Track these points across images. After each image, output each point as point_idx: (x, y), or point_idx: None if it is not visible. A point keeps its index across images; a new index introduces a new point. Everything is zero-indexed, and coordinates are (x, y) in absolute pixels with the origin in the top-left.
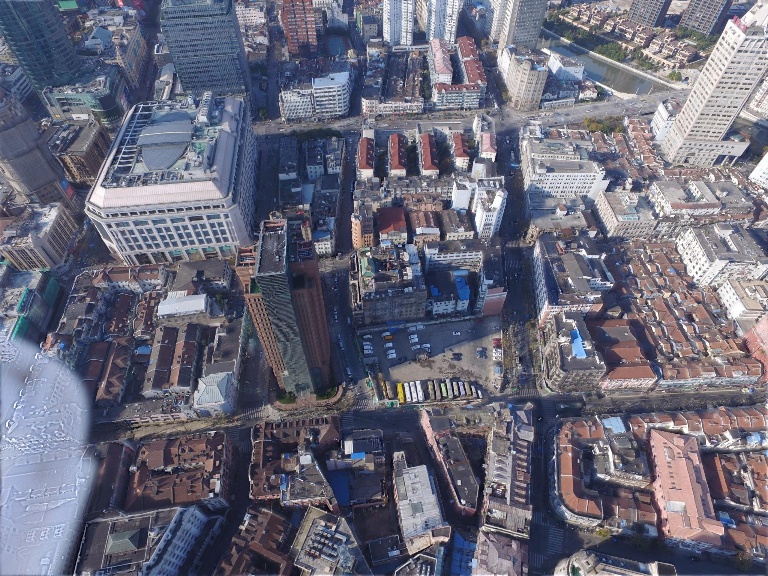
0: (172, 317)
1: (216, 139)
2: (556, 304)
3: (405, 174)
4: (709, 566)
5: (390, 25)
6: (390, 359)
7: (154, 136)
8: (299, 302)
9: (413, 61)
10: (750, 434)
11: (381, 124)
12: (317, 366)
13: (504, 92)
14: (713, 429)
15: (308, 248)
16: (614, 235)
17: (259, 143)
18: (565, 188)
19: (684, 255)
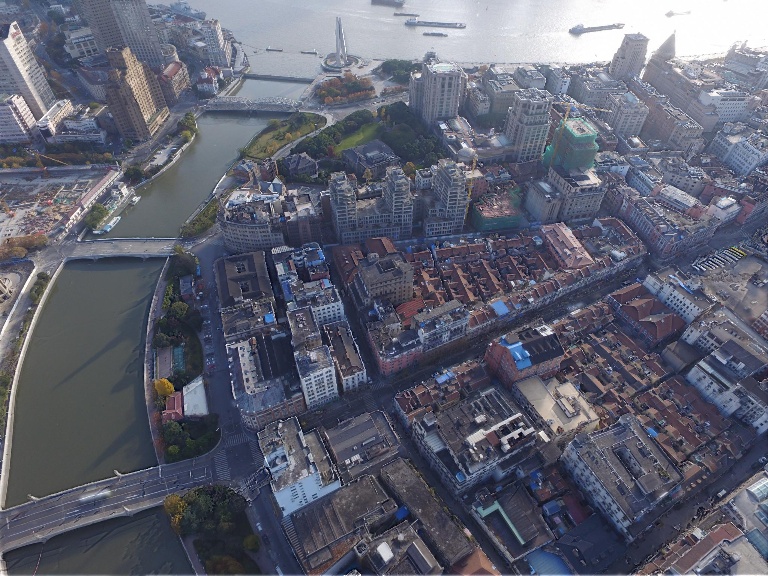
0: None
1: None
2: (723, 309)
3: None
4: None
5: None
6: None
7: None
8: None
9: None
10: None
11: None
12: None
13: None
14: None
15: None
16: None
17: None
18: None
19: None
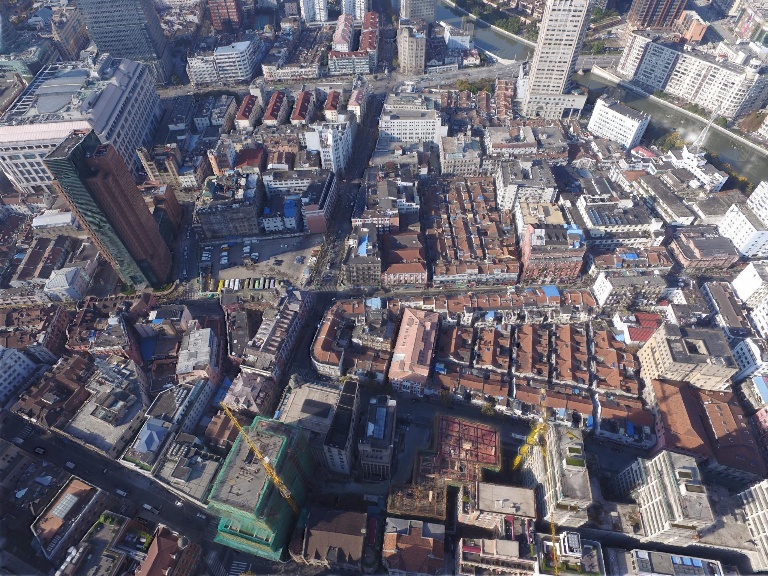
0: (45, 228)
1: (102, 90)
2: (358, 218)
3: (277, 124)
4: (426, 406)
5: (303, 2)
6: (222, 264)
7: (50, 88)
8: (97, 191)
9: (322, 34)
10: (487, 312)
11: (279, 88)
12: (142, 258)
13: (394, 59)
14: (456, 308)
15: (105, 149)
16: (445, 172)
17: (166, 103)
18: (412, 134)
19: (497, 186)
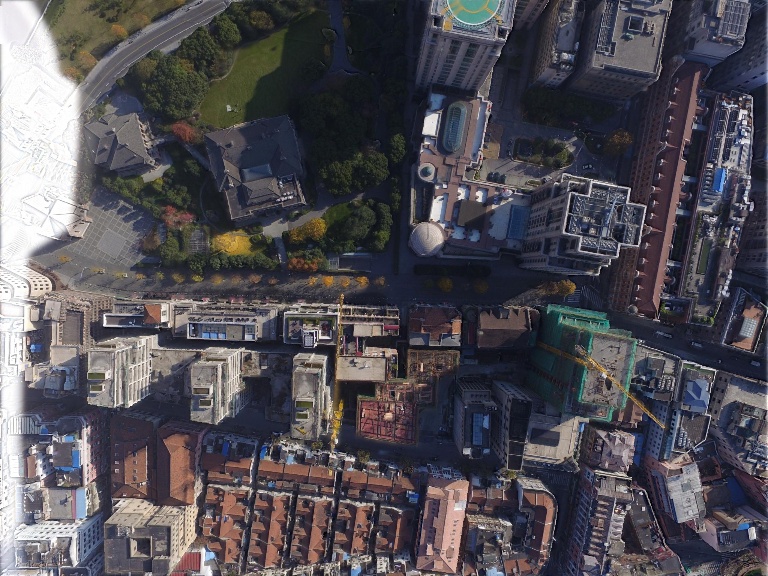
0: None
1: None
2: None
3: None
4: (423, 455)
5: None
6: None
7: None
8: None
9: None
10: (359, 575)
11: None
12: None
13: None
14: None
15: None
16: None
17: None
18: None
19: None
